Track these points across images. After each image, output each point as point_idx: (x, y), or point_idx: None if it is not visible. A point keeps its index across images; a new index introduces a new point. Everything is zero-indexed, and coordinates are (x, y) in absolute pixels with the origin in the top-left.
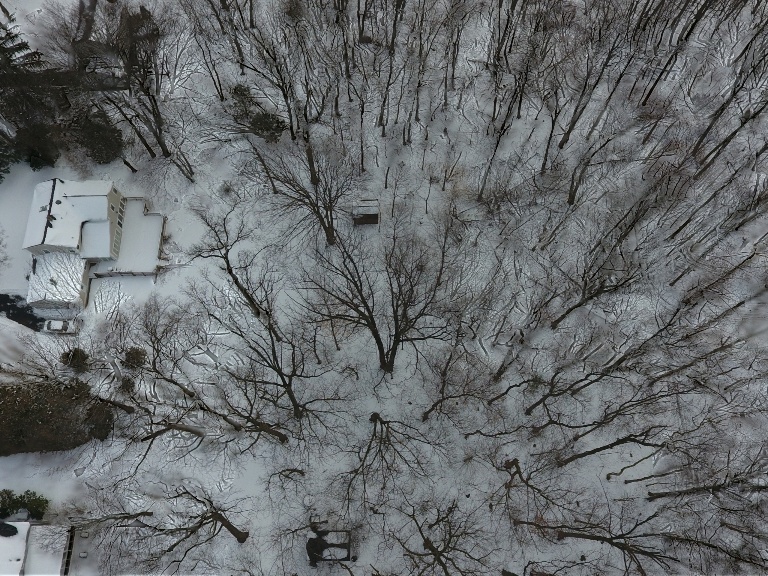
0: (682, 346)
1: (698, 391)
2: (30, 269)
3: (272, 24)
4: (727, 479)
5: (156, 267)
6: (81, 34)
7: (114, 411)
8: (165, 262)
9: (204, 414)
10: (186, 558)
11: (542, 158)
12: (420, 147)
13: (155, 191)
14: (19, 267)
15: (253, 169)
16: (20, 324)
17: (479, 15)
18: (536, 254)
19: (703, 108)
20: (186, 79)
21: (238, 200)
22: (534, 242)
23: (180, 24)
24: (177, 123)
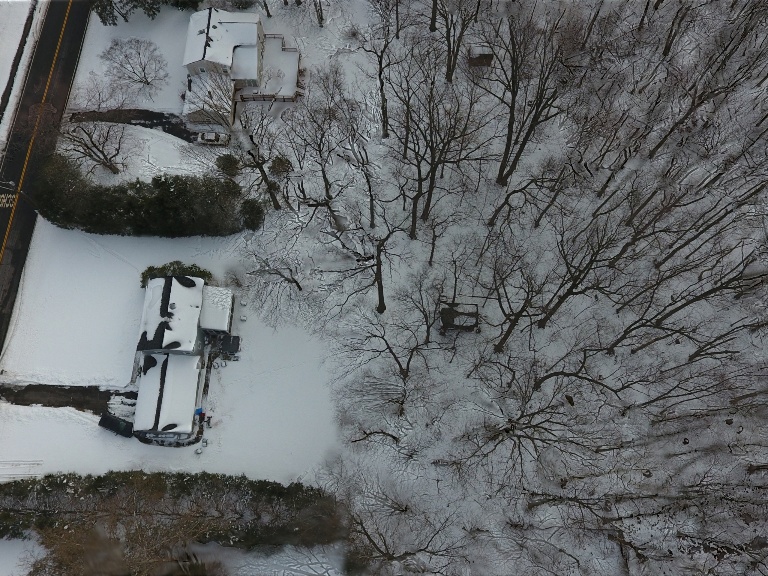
0: None
1: None
2: (184, 90)
3: None
4: None
5: (295, 92)
6: None
7: (264, 207)
8: (302, 90)
9: (346, 208)
10: (347, 303)
11: (639, 16)
12: (528, 3)
13: (301, 19)
14: (174, 88)
15: (386, 6)
16: (175, 136)
17: None
18: (634, 97)
19: None
20: None
21: (364, 42)
22: None
23: None
24: None
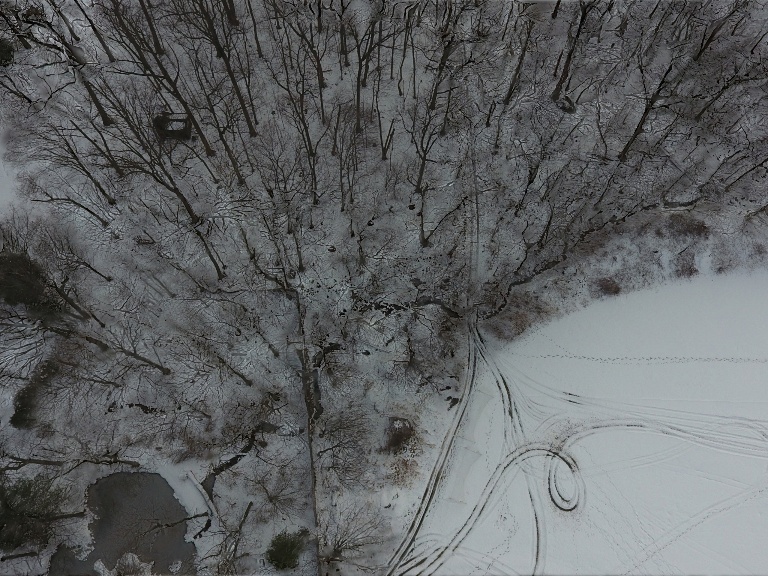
0: (471, 9)
1: (481, 41)
2: None
3: None
4: None
5: None
6: None
7: (15, 46)
8: None
9: None
10: (52, 100)
11: None
12: None
13: None
14: None
15: None
16: None
17: None
18: None
19: None
20: None
21: None
22: None
23: None
24: None
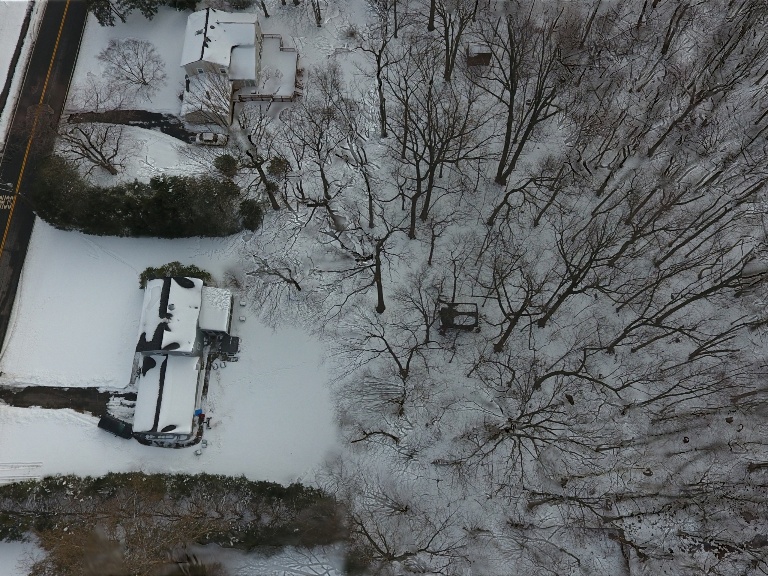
0: None
1: None
2: (182, 90)
3: None
4: None
5: (294, 92)
6: None
7: (263, 207)
8: (300, 90)
9: (345, 208)
10: (347, 303)
11: (637, 15)
12: (526, 1)
13: (299, 19)
14: (172, 88)
15: (384, 5)
16: (174, 137)
17: None
18: (633, 95)
19: None
20: None
21: (362, 42)
22: None
23: None
24: None
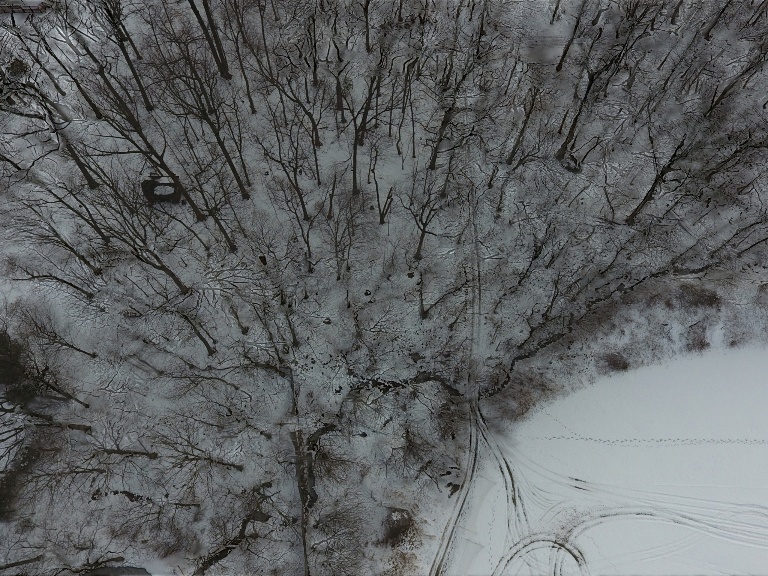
0: None
1: (483, 95)
2: None
3: None
4: None
5: (41, 3)
6: None
7: None
8: (50, 3)
9: None
10: (34, 167)
11: None
12: None
13: None
14: None
15: None
16: None
17: None
18: None
19: None
20: None
21: None
22: None
23: None
24: None
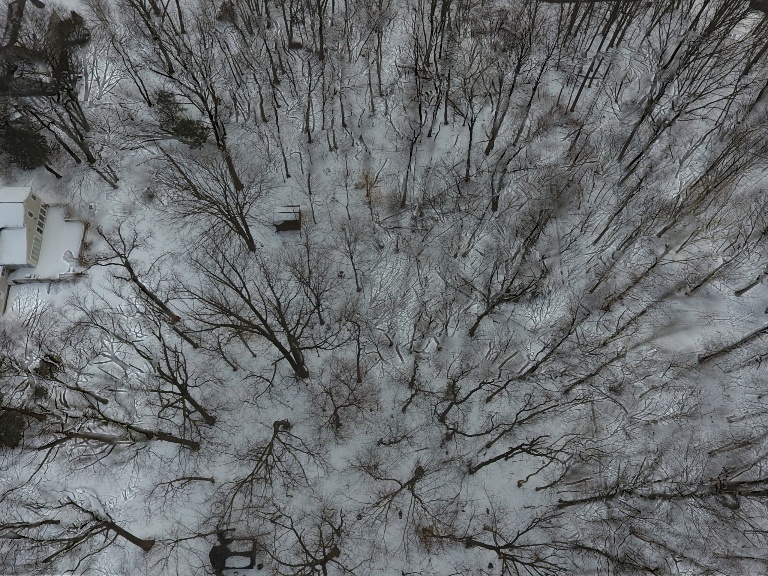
0: (599, 354)
1: None
2: None
3: (201, 30)
4: (617, 489)
5: None
6: (8, 39)
7: (25, 419)
8: None
9: None
10: (80, 567)
11: None
12: None
13: (70, 198)
14: None
15: (171, 176)
16: None
17: (403, 22)
18: (458, 261)
19: (630, 115)
20: (115, 85)
21: (161, 206)
22: (454, 249)
23: (110, 29)
24: (103, 129)
